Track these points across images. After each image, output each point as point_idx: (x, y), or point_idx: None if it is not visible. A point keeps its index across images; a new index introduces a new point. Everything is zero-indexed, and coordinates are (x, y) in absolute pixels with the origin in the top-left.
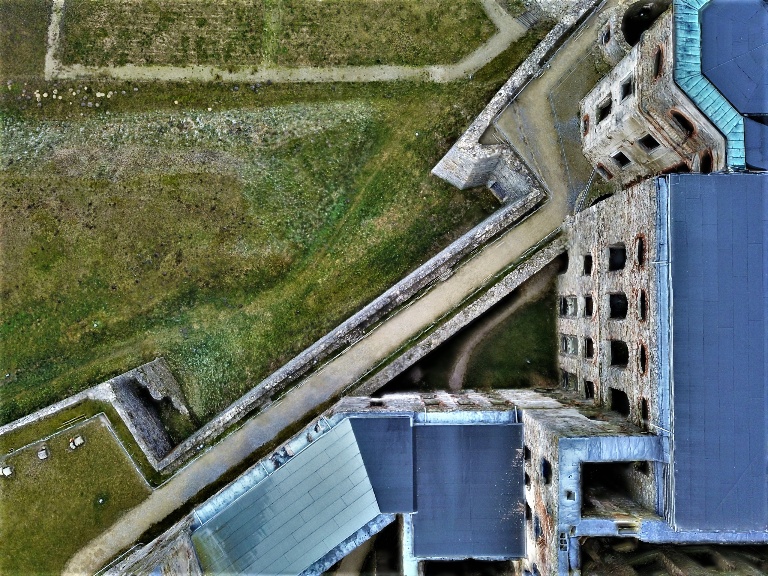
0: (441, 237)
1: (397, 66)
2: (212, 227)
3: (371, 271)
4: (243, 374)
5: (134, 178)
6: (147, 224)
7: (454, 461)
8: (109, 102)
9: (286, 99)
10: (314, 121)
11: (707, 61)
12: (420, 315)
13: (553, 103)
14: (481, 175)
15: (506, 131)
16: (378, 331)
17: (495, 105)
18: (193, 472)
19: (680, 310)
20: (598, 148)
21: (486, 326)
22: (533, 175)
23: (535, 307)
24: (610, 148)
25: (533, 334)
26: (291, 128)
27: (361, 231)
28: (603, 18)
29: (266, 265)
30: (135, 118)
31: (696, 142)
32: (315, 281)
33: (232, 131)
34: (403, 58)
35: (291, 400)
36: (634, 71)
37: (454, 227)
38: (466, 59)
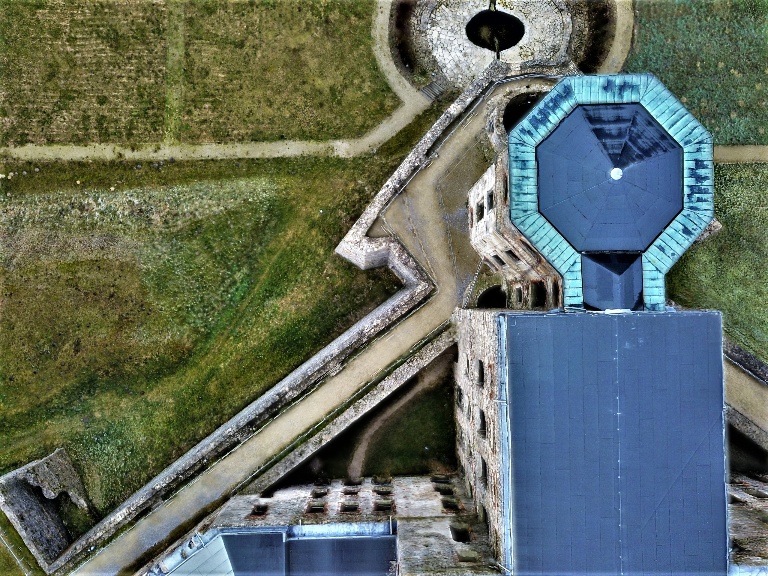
0: (344, 318)
1: (301, 141)
2: (111, 315)
3: (273, 354)
4: (145, 463)
5: (31, 266)
6: (44, 314)
7: (328, 575)
8: (10, 183)
9: (190, 177)
10: (216, 201)
11: (544, 199)
12: (310, 410)
13: (441, 193)
14: (378, 260)
15: (395, 222)
16: (268, 428)
17: (383, 197)
18: (85, 574)
19: (518, 452)
20: (480, 245)
21: (384, 413)
22: (421, 268)
23: (433, 392)
24: (488, 249)
25: (431, 420)
26: (193, 209)
27: (264, 313)
28: (491, 105)
29: (166, 352)
30: (36, 200)
31: (546, 269)
32: (217, 366)
33: (133, 212)
34: (307, 133)
35: (182, 499)
36: (494, 188)
37: (357, 307)
38: (371, 133)
